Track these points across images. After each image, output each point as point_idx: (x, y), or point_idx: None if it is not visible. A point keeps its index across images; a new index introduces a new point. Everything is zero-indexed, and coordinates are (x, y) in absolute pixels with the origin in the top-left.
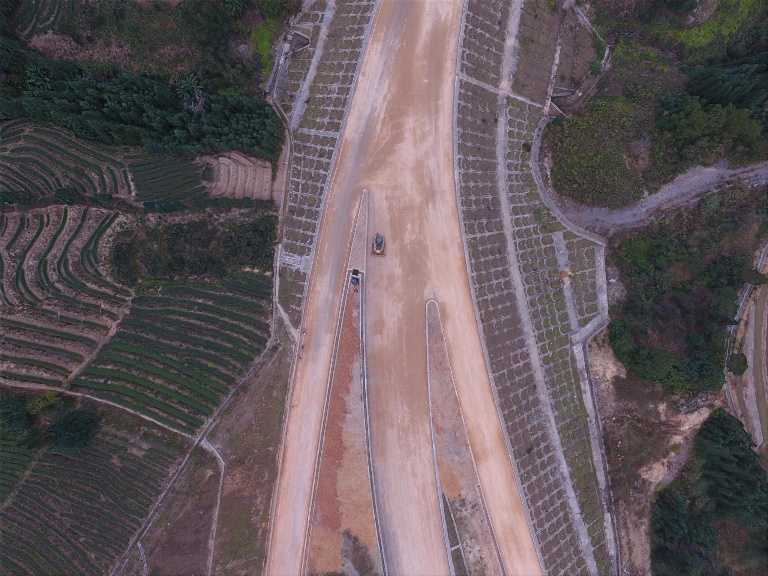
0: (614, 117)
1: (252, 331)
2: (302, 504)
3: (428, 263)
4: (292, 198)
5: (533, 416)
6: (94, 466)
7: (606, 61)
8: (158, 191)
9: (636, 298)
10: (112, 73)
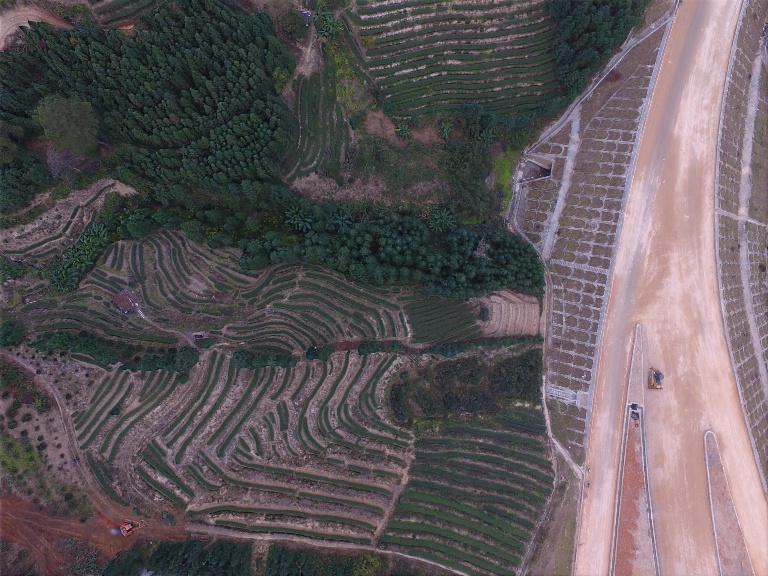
0: None
1: (538, 470)
2: None
3: (702, 394)
4: (555, 330)
5: None
6: None
7: None
8: (434, 332)
9: None
10: (365, 209)
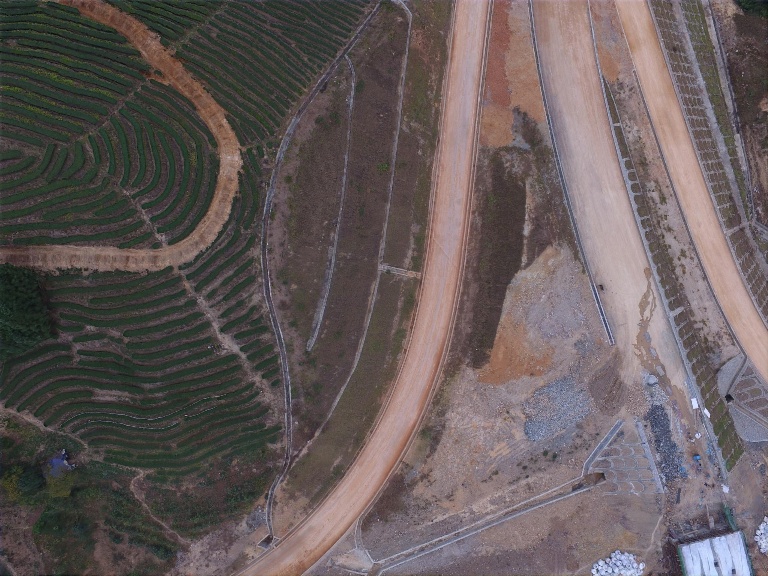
0: None
1: None
2: (471, 88)
3: None
4: None
5: (673, 27)
6: None
7: None
8: None
9: None
10: None
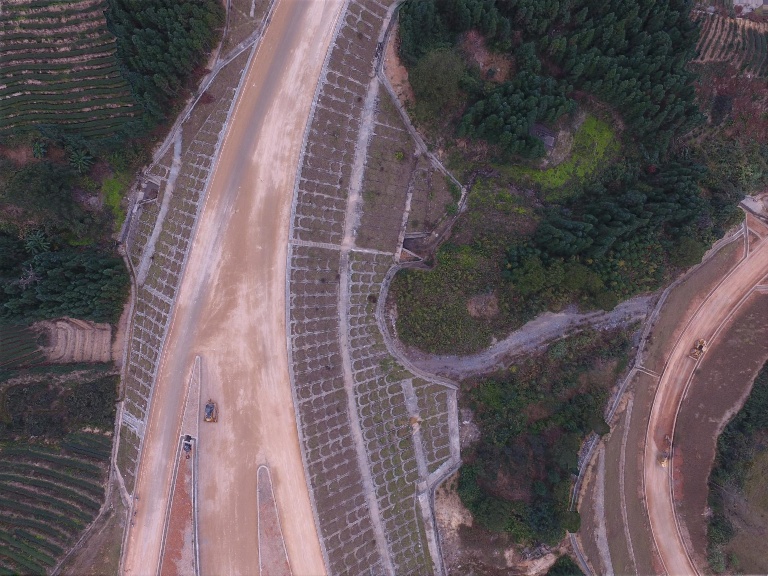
0: (457, 271)
1: (86, 497)
2: None
3: (260, 428)
4: (133, 357)
5: (370, 573)
6: None
7: (463, 202)
8: None
9: (487, 441)
10: None
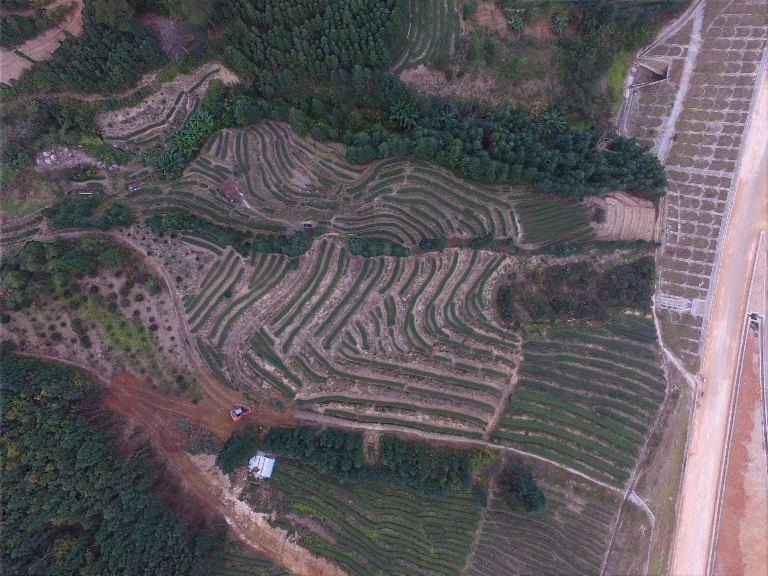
0: None
1: (650, 377)
2: (699, 554)
3: None
4: (669, 238)
5: None
6: (540, 524)
7: None
8: (546, 233)
9: None
10: (471, 108)
